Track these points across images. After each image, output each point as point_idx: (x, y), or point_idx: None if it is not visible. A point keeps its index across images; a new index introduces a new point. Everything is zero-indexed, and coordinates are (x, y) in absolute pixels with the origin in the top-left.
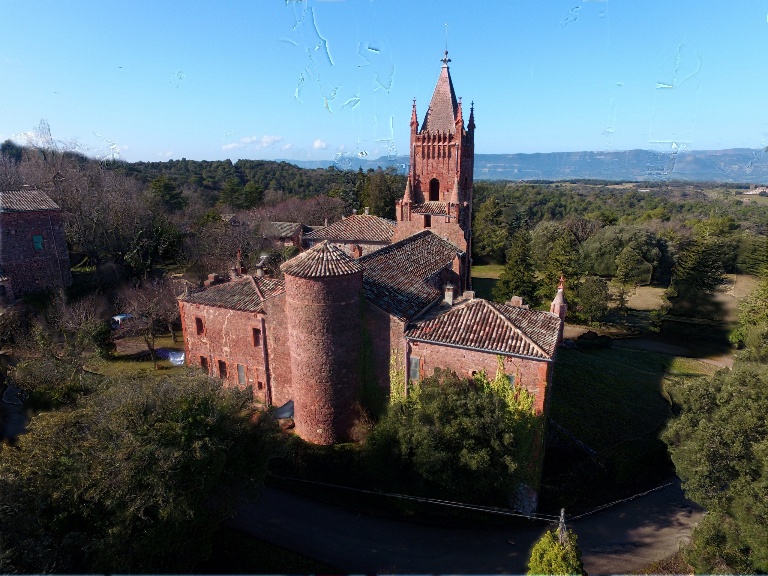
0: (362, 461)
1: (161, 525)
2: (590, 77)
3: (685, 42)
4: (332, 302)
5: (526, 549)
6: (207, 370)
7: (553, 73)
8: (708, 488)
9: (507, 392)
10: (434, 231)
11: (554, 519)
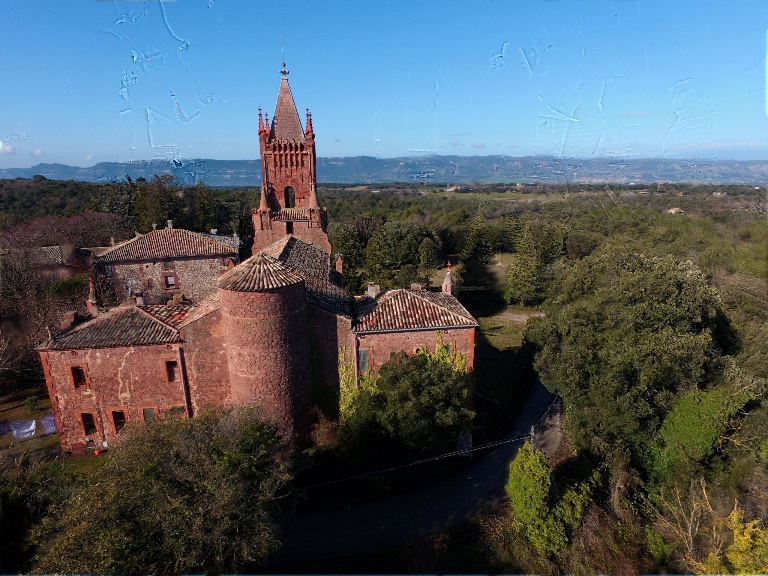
0: (345, 455)
1: (238, 572)
2: (523, 109)
3: (441, 73)
4: (288, 312)
5: (481, 478)
6: (91, 429)
7: (491, 104)
8: (575, 391)
9: (446, 359)
10: (297, 237)
11: (527, 436)
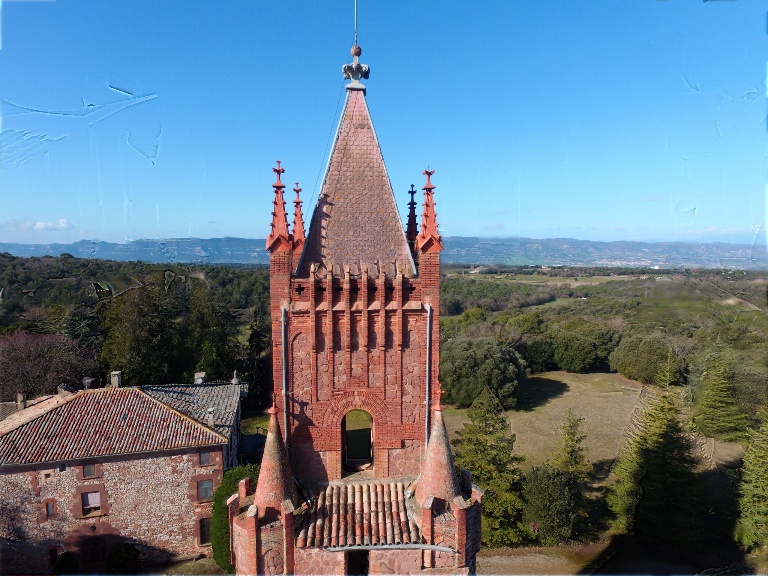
0: None
1: None
2: None
3: (575, 134)
4: None
5: None
6: None
7: None
8: None
9: None
10: None
11: None
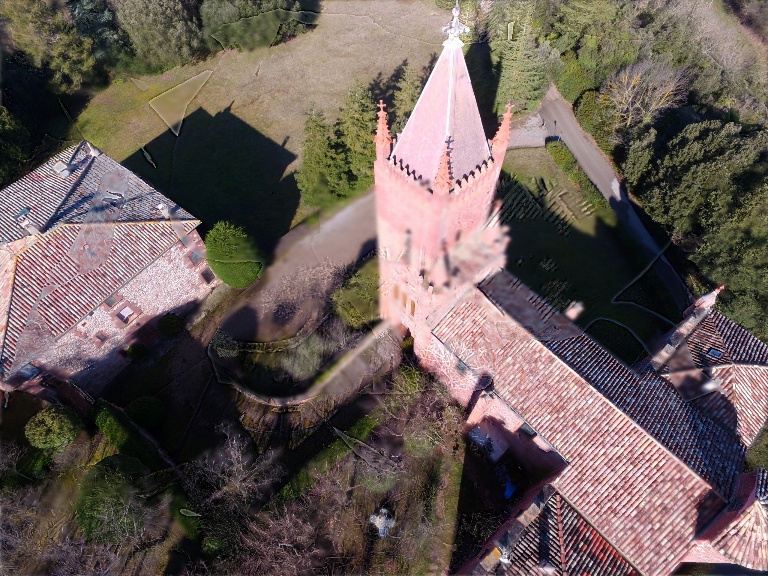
0: None
1: None
2: None
3: None
4: None
5: None
6: None
7: None
8: None
9: None
10: None
11: None
